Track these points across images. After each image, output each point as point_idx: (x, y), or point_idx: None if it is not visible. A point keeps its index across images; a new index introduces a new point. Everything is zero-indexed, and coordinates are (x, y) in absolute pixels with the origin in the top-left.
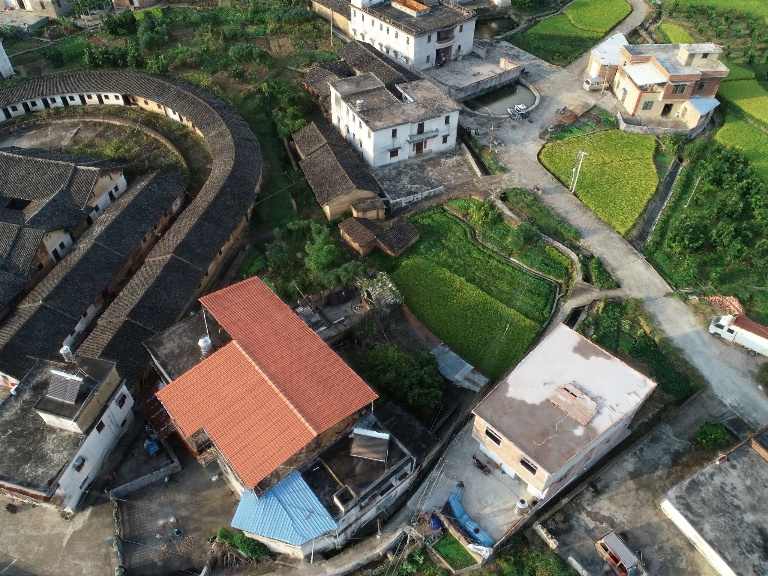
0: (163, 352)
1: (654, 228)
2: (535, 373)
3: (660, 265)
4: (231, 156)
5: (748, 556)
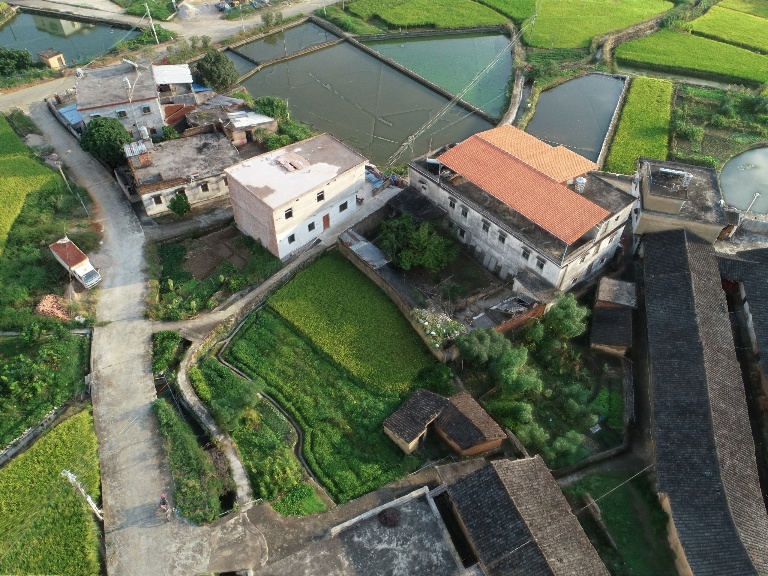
0: (615, 193)
1: (27, 430)
2: (313, 178)
3: (77, 366)
4: (763, 571)
5: (218, 145)
